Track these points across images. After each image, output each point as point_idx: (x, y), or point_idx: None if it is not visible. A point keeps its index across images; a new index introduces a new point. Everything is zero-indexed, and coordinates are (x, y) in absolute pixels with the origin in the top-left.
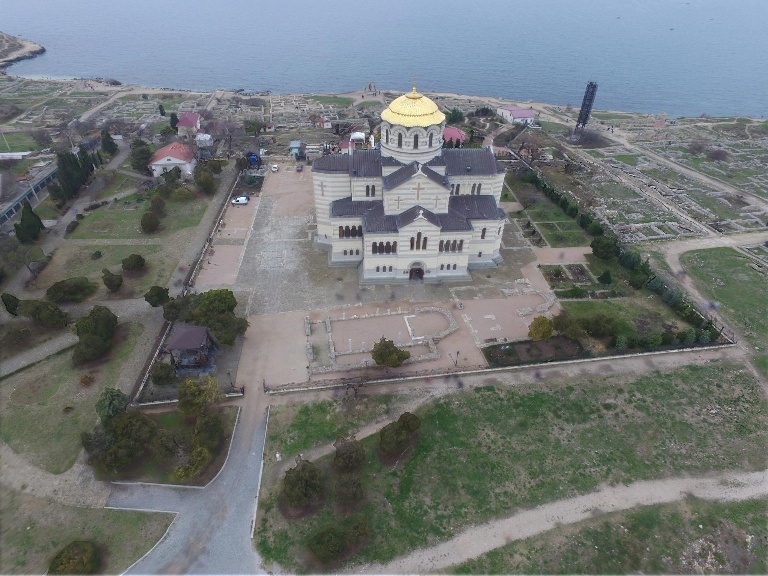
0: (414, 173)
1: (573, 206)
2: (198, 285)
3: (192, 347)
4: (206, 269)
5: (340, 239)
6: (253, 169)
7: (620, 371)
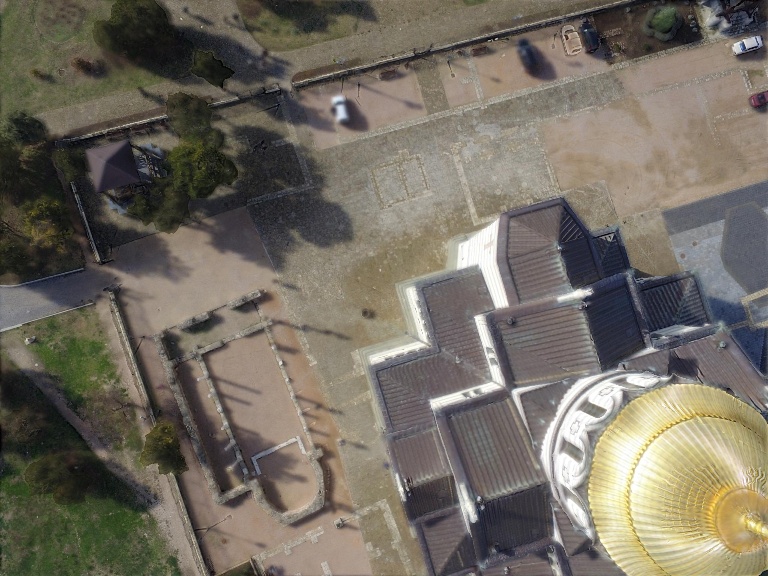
0: (478, 489)
1: None
2: (298, 98)
3: (95, 182)
4: (342, 88)
5: (416, 302)
6: (721, 2)
7: None
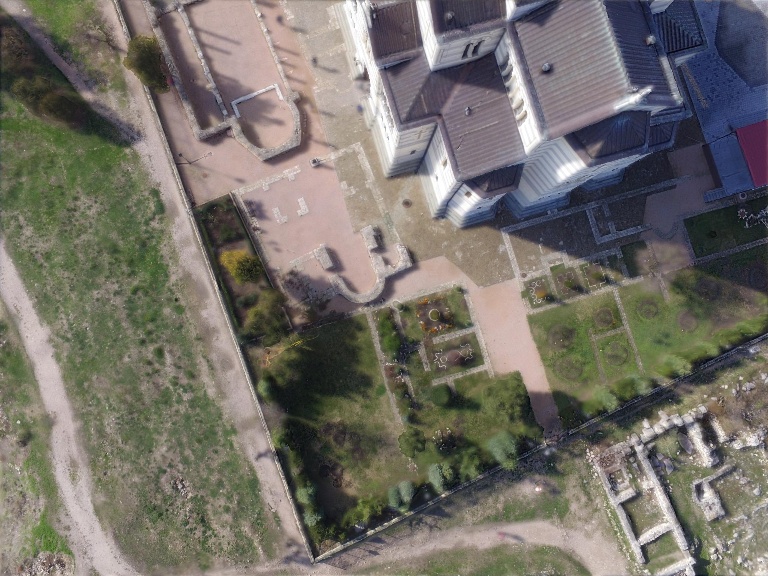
0: None
1: (677, 366)
2: None
3: None
4: None
5: None
6: None
7: (223, 380)
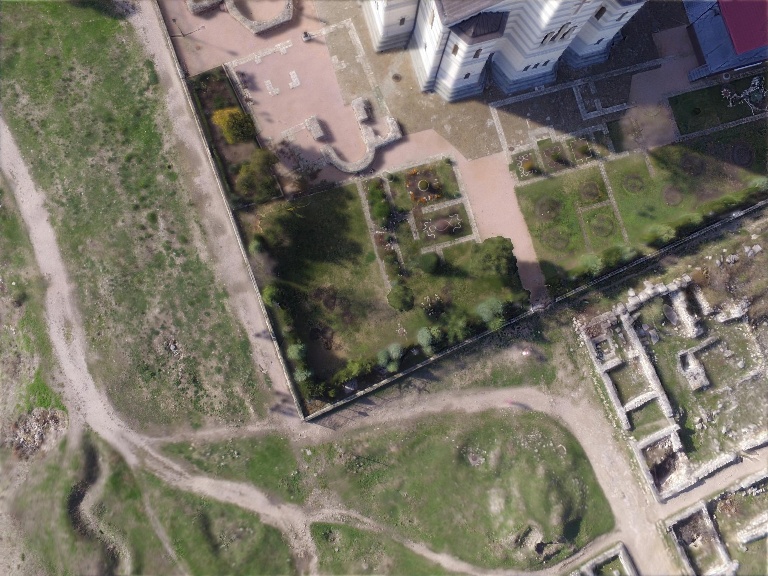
0: None
1: (661, 231)
2: None
3: None
4: None
5: None
6: None
7: (215, 244)
